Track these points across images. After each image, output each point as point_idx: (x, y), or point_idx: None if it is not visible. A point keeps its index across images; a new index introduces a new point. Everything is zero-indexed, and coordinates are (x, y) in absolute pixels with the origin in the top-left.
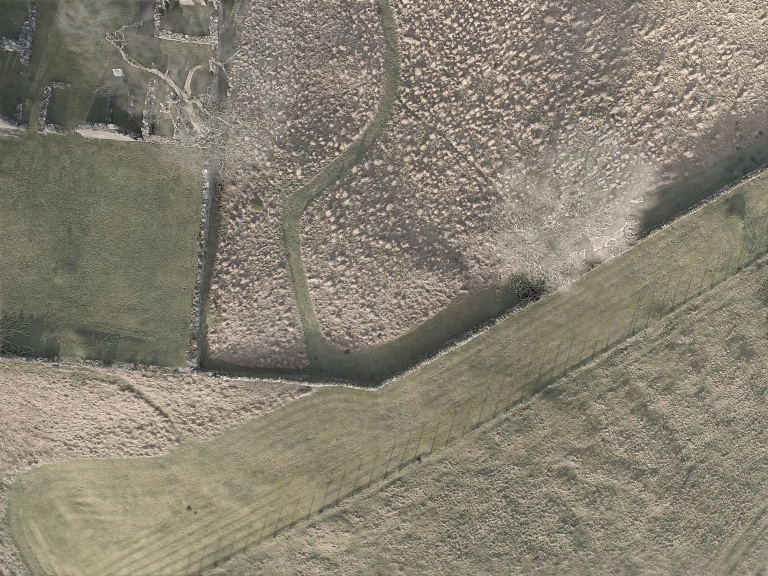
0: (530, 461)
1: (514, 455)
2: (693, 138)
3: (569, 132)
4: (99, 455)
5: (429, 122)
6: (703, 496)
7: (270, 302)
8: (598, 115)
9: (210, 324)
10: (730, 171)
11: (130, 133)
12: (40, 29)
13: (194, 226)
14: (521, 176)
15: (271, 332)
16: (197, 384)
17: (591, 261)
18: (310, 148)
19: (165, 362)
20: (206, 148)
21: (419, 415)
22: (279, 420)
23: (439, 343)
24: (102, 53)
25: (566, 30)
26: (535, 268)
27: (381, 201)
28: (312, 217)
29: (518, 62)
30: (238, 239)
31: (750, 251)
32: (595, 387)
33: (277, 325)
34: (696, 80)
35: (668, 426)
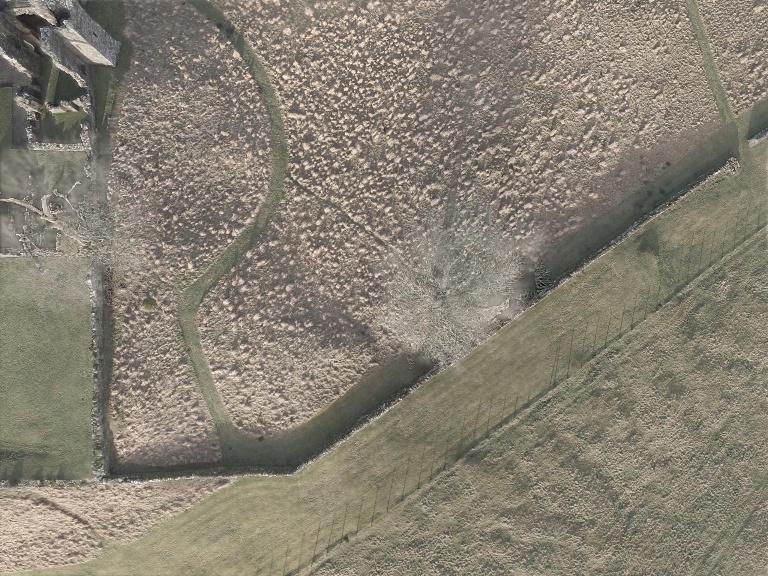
0: (461, 528)
1: (443, 523)
2: (597, 178)
3: (467, 188)
4: (24, 568)
5: (322, 196)
6: (646, 541)
7: (175, 399)
8: (495, 168)
9: (114, 430)
10: (639, 206)
11: (11, 250)
12: None
13: (86, 335)
14: (422, 239)
15: (180, 429)
16: (111, 490)
17: (502, 317)
18: (201, 239)
19: (71, 475)
20: (90, 256)
21: (341, 494)
22: (200, 515)
23: (353, 419)
24: None
25: (454, 85)
26: (445, 331)
27: (280, 282)
28: (209, 308)
29: (408, 124)
30: (134, 341)
31: (669, 285)
32: (521, 444)
33: (185, 421)
34: (594, 118)
35: (602, 474)
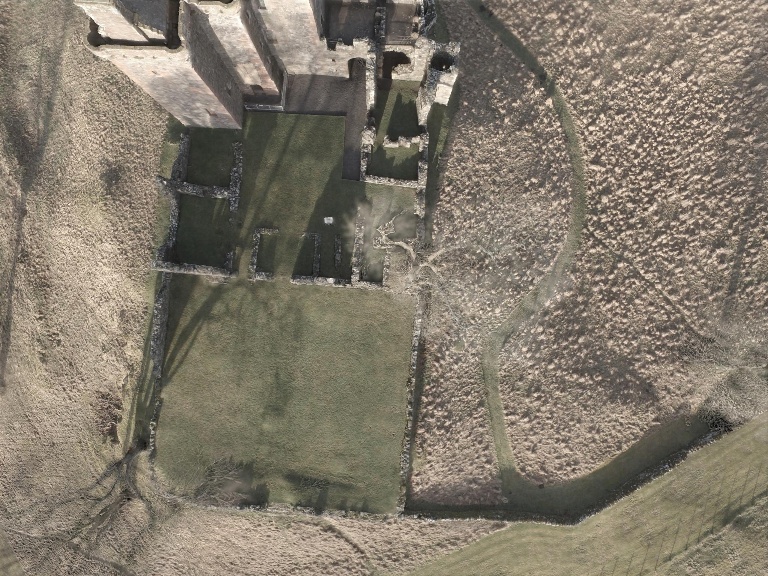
0: None
1: None
2: None
3: (753, 255)
4: None
5: (616, 250)
6: None
7: (470, 441)
8: None
9: (416, 467)
10: None
11: (342, 282)
12: (247, 175)
13: (403, 372)
14: (707, 302)
15: (470, 470)
16: (397, 523)
17: None
18: (506, 284)
19: (375, 509)
20: None
21: (612, 548)
22: (473, 555)
23: (632, 476)
24: (308, 198)
25: (748, 151)
26: (724, 396)
27: (573, 333)
28: (509, 354)
29: (702, 186)
30: (442, 381)
31: None
32: None
33: (475, 463)
34: None
35: None
